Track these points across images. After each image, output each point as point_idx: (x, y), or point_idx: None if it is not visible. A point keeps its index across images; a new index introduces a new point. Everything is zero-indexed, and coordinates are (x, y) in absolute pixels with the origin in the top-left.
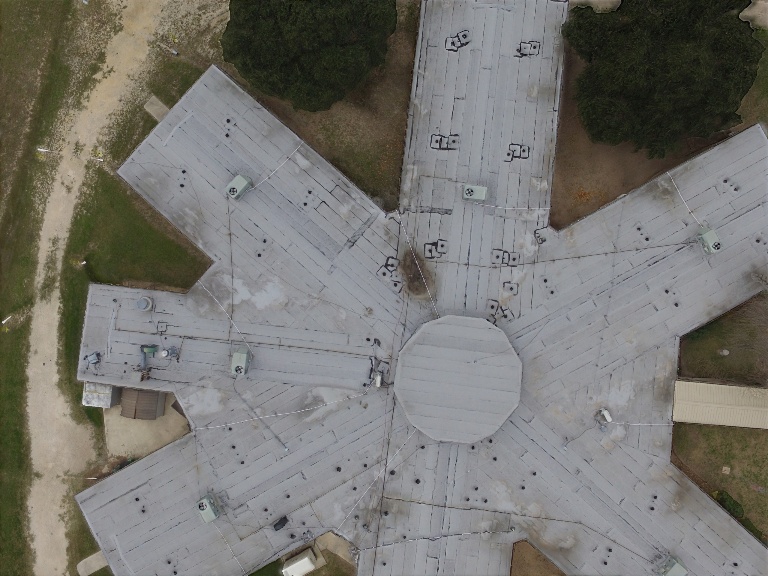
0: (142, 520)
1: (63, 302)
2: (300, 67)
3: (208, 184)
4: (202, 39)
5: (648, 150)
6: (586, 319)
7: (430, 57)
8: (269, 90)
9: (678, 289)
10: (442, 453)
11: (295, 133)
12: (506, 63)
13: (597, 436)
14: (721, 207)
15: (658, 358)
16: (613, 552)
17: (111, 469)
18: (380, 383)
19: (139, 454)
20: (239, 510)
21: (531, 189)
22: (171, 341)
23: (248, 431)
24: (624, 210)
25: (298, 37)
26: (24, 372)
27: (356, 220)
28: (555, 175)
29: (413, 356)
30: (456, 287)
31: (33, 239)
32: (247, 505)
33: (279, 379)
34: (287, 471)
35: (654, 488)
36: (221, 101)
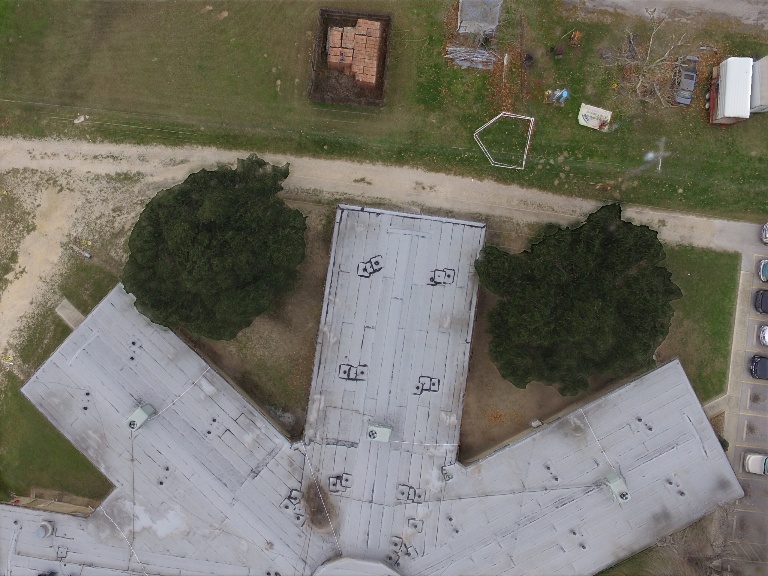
0: None
1: None
2: (202, 304)
3: (112, 407)
4: (116, 241)
5: (561, 388)
6: (491, 560)
7: (341, 283)
8: (170, 325)
9: (587, 530)
10: None
11: (201, 357)
12: (419, 292)
13: None
14: (634, 447)
15: None
16: None
17: None
18: None
19: None
20: None
21: (440, 424)
22: (70, 569)
23: None
24: (534, 448)
25: (195, 286)
26: None
27: (261, 450)
28: (471, 395)
29: None
30: (359, 524)
31: None
32: None
33: None
34: None
35: None
36: (127, 321)
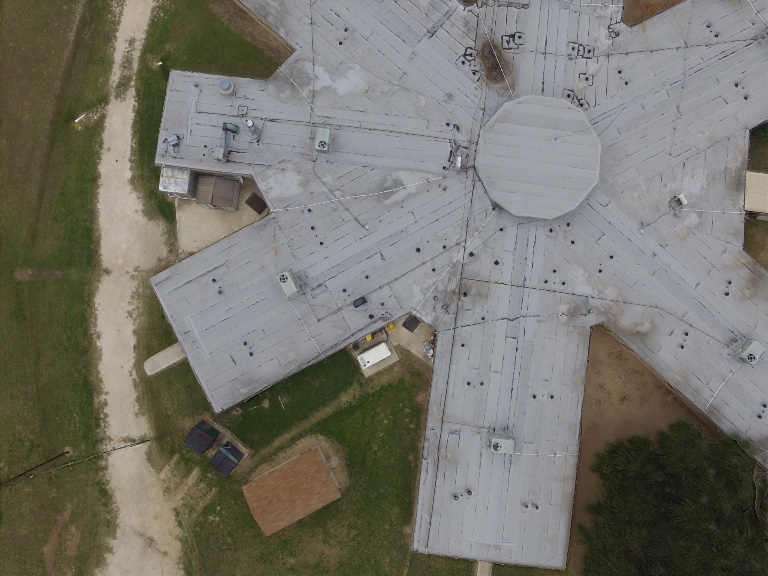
0: (218, 301)
1: (138, 101)
2: None
3: None
4: None
5: None
6: (659, 109)
7: None
8: None
9: (747, 84)
10: (521, 234)
11: None
12: None
13: (672, 222)
14: None
15: (729, 149)
16: (689, 337)
17: None
18: (460, 163)
19: None
20: (317, 291)
21: None
22: None
23: (327, 213)
24: (693, 9)
25: None
26: (96, 169)
27: (435, 12)
28: None
29: (494, 133)
30: (533, 75)
31: (109, 40)
32: (325, 285)
33: (359, 162)
34: (366, 251)
35: (728, 274)
36: None
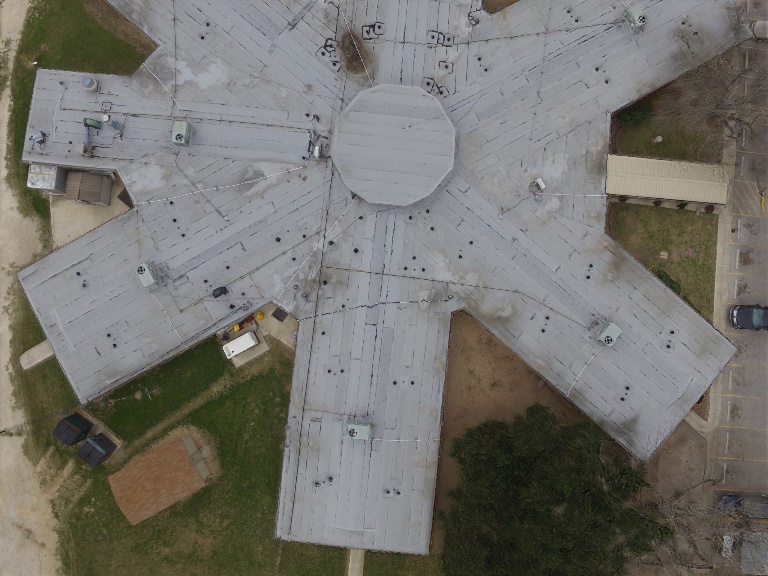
0: (83, 294)
1: (13, 100)
2: None
3: None
4: None
5: None
6: (519, 95)
7: None
8: None
9: (608, 68)
10: (379, 222)
11: None
12: None
13: (532, 207)
14: None
15: (590, 133)
16: (550, 320)
17: None
18: (318, 152)
19: None
20: (179, 282)
21: None
22: (115, 118)
23: (189, 205)
24: None
25: None
26: None
27: (296, 5)
28: None
29: (349, 122)
30: (392, 64)
31: None
32: (187, 277)
33: (220, 154)
34: (227, 241)
35: (589, 258)
36: None
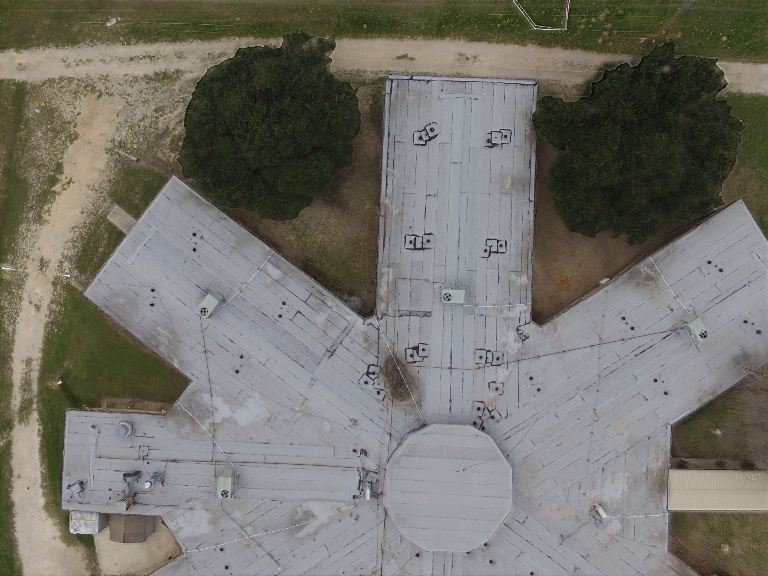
0: None
1: (42, 424)
2: (263, 180)
3: (179, 301)
4: (162, 142)
5: (629, 236)
6: (575, 414)
7: (398, 153)
8: (233, 206)
9: (667, 376)
10: (437, 560)
11: (264, 242)
12: (477, 155)
13: (592, 531)
14: (706, 289)
15: (650, 448)
16: None
17: None
18: (369, 496)
19: (132, 572)
20: None
21: (511, 284)
22: (154, 466)
23: (239, 550)
24: (607, 299)
25: (258, 155)
26: (9, 497)
27: (333, 329)
28: (535, 261)
29: (401, 468)
30: (440, 392)
31: (5, 362)
32: None
33: (267, 496)
34: None
35: None
36: (185, 214)
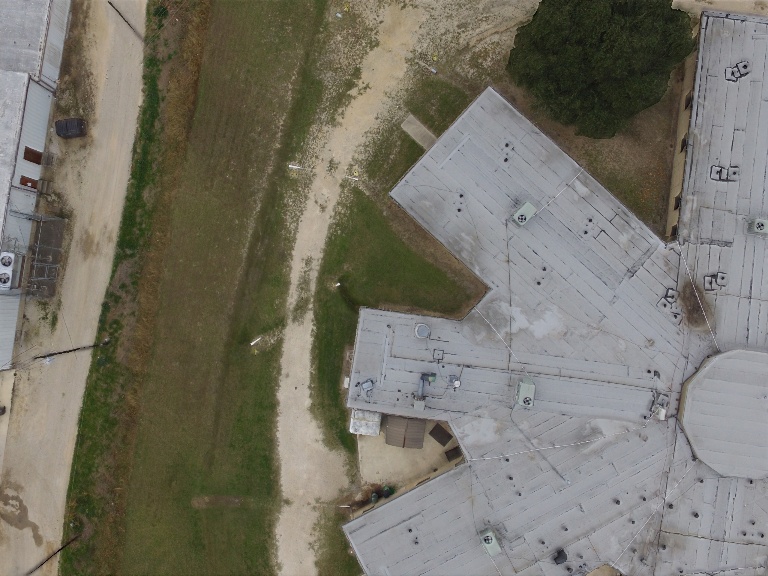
0: (415, 552)
1: (316, 325)
2: (597, 94)
3: (485, 209)
4: (461, 58)
5: None
6: None
7: (710, 87)
8: (564, 117)
9: None
10: (722, 487)
11: (574, 160)
12: None
13: None
14: None
15: None
16: None
17: (365, 497)
18: (665, 417)
19: (395, 482)
20: (515, 543)
21: None
22: (449, 370)
23: (525, 462)
24: None
25: (611, 65)
26: (275, 396)
27: (636, 250)
28: None
29: (703, 390)
30: (737, 321)
31: (285, 259)
32: (524, 538)
33: (558, 410)
34: (566, 504)
35: None
36: (498, 124)
